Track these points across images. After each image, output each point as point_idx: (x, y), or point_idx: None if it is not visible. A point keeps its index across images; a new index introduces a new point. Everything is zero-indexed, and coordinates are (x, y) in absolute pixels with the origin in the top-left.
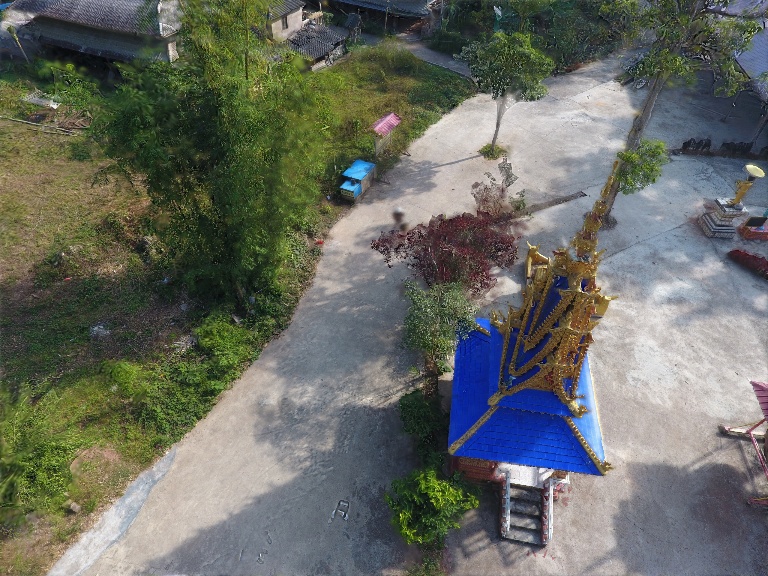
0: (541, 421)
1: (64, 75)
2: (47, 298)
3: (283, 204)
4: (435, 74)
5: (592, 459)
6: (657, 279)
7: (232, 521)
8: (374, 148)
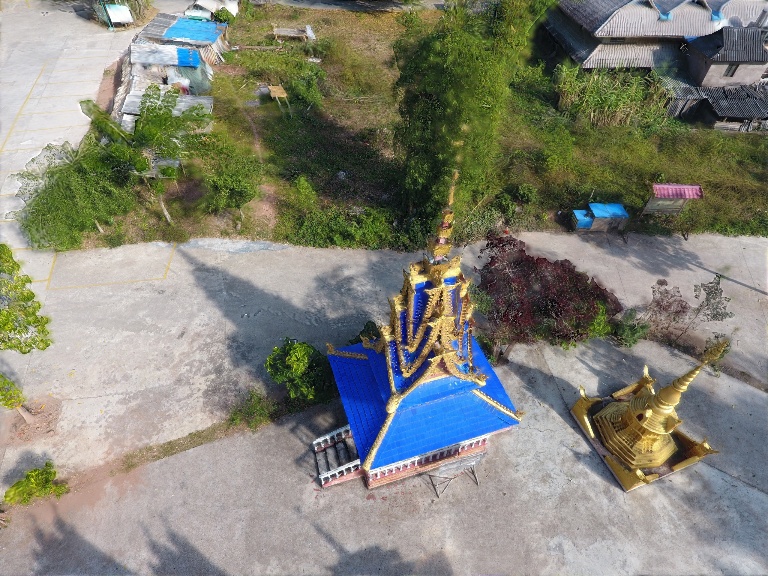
0: (380, 396)
1: (410, 7)
2: (348, 145)
3: (445, 153)
4: None
5: (370, 450)
6: (765, 557)
7: (260, 292)
8: None
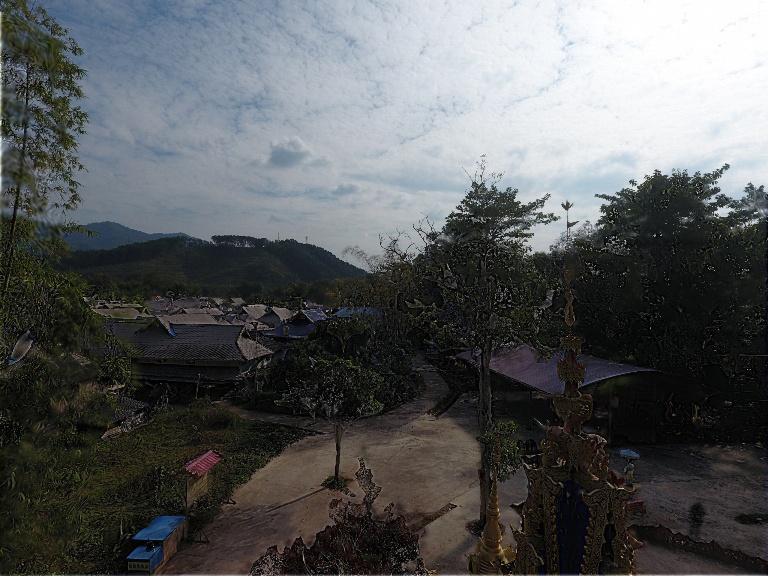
0: None
1: None
2: None
3: (1, 546)
4: (256, 425)
5: None
6: None
7: None
8: (184, 502)
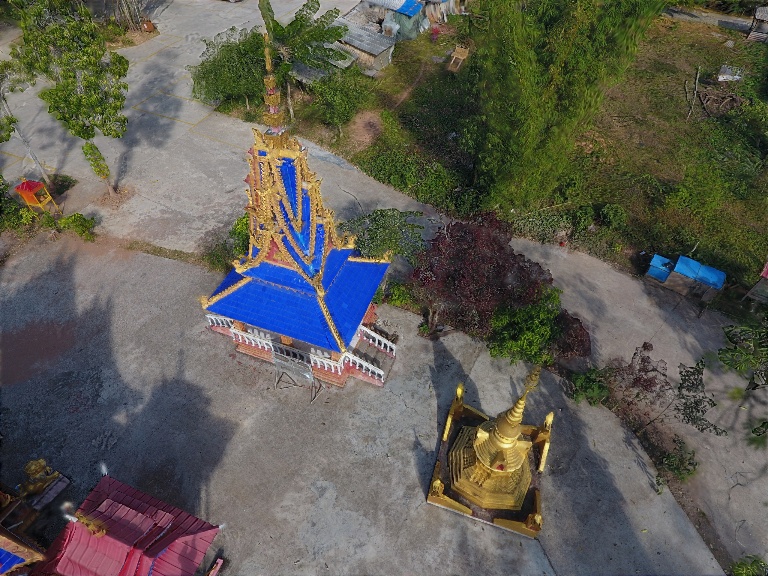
0: None
1: None
2: None
3: None
4: None
5: None
6: None
7: None
8: None
